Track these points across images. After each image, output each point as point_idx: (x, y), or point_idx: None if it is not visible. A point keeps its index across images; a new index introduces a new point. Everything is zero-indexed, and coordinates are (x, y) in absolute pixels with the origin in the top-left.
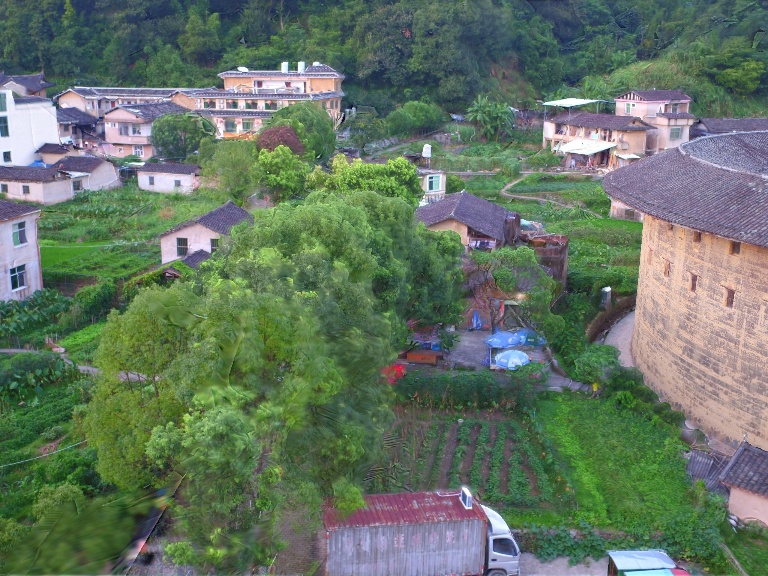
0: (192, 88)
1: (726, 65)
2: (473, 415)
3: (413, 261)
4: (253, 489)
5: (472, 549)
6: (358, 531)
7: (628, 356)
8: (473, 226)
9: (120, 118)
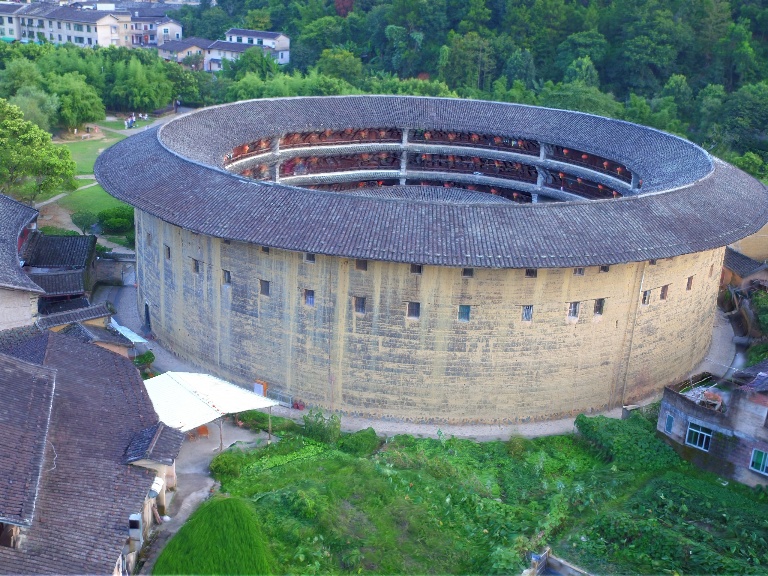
0: None
1: None
2: None
3: None
4: None
5: None
6: None
7: None
8: None
9: None
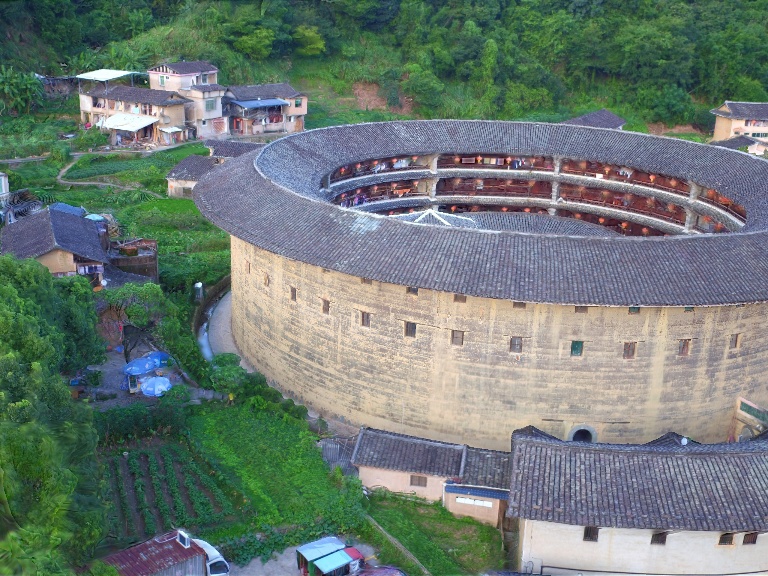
0: None
1: (241, 32)
2: (135, 446)
3: (55, 317)
4: None
5: None
6: None
7: (234, 349)
8: (79, 253)
9: None
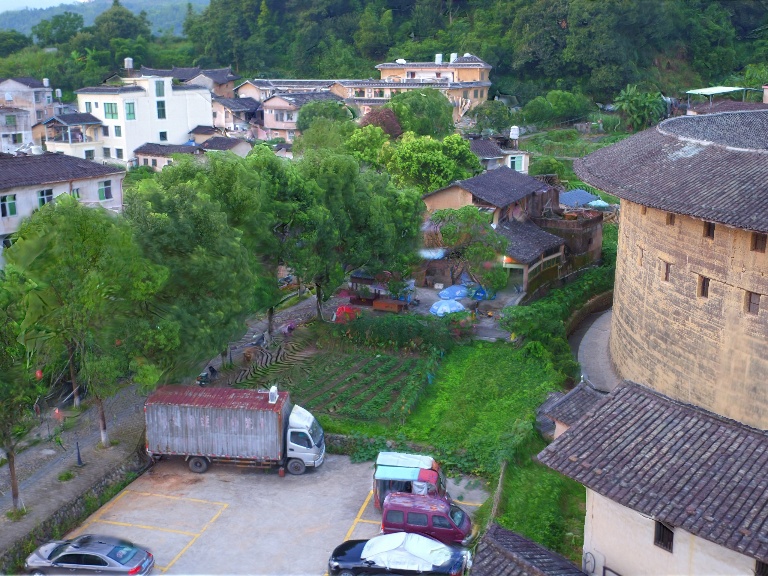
0: (353, 79)
1: None
2: (392, 352)
3: (357, 212)
4: (4, 338)
5: (269, 436)
6: (170, 408)
7: None
8: (476, 193)
9: (276, 105)
